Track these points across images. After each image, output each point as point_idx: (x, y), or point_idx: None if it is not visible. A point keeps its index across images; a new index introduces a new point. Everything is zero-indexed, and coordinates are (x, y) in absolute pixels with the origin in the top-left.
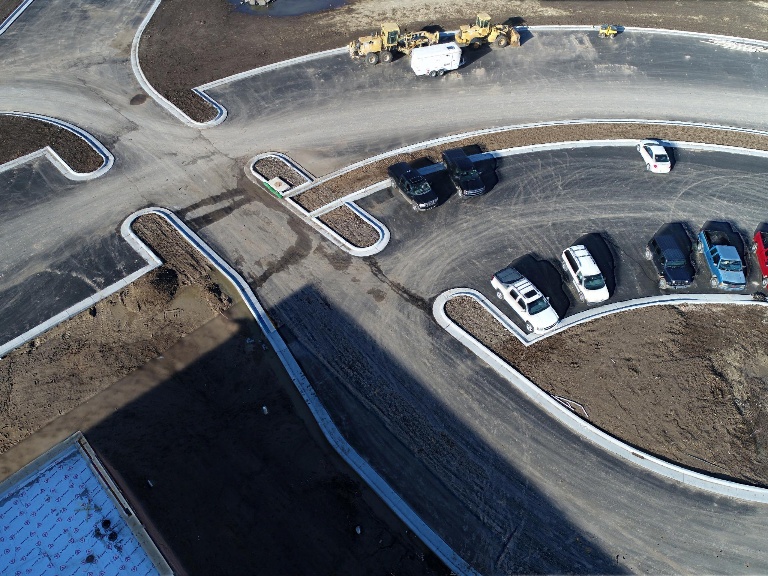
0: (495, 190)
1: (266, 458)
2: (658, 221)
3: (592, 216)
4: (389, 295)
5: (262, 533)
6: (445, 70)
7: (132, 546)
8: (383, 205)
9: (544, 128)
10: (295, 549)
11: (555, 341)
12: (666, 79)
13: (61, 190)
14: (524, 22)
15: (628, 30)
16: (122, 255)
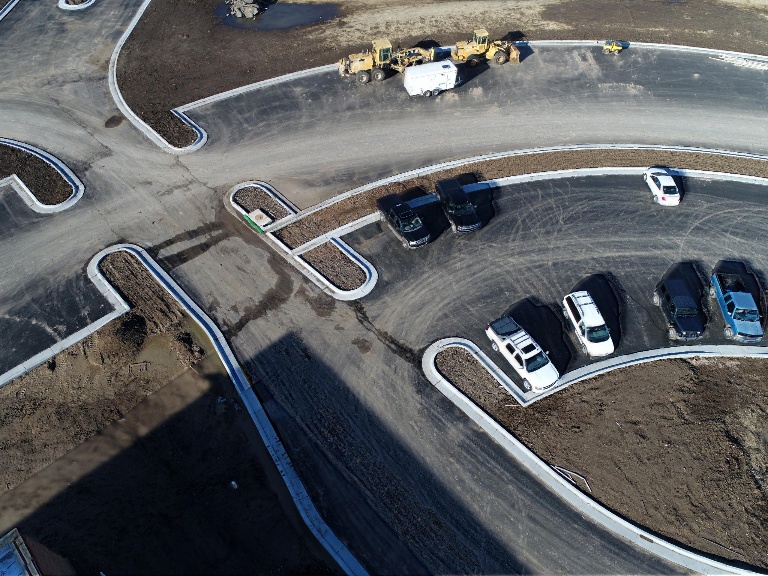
0: (491, 224)
1: (234, 542)
2: (667, 260)
3: (595, 255)
4: (375, 346)
5: None
6: (440, 90)
7: None
8: (371, 241)
9: (544, 154)
10: None
11: (555, 401)
12: (674, 100)
13: (26, 224)
14: (524, 37)
15: (633, 45)
16: (87, 299)
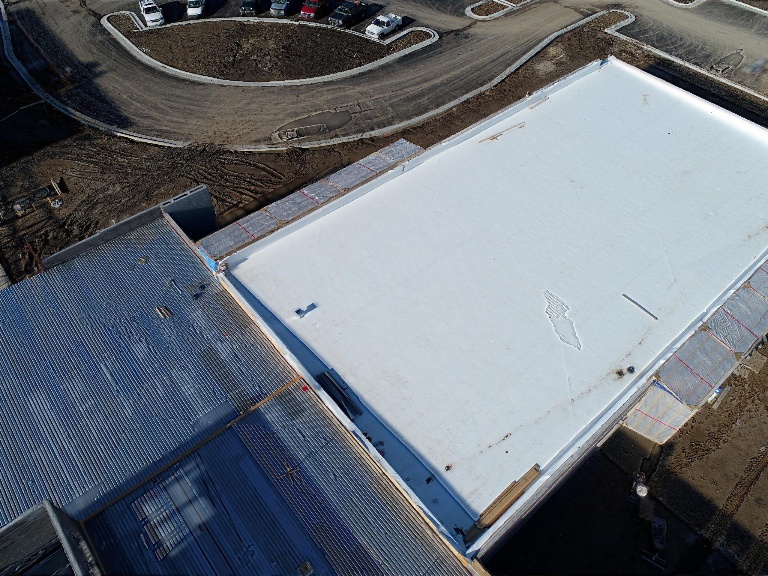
0: None
1: None
2: None
3: None
4: (82, 12)
5: None
6: None
7: None
8: None
9: None
10: None
11: (159, 30)
12: None
13: None
14: None
15: None
16: None
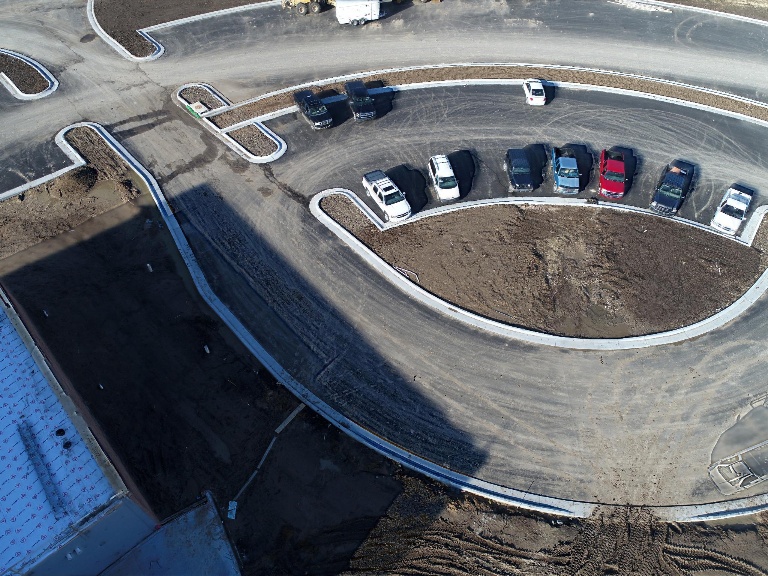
0: (387, 116)
1: (145, 302)
2: (523, 142)
3: (466, 137)
4: (275, 192)
5: (131, 351)
6: (366, 20)
7: (9, 330)
8: (286, 125)
9: (444, 69)
10: (155, 362)
11: (407, 228)
12: (566, 32)
13: (9, 107)
14: None
15: None
16: (53, 157)
